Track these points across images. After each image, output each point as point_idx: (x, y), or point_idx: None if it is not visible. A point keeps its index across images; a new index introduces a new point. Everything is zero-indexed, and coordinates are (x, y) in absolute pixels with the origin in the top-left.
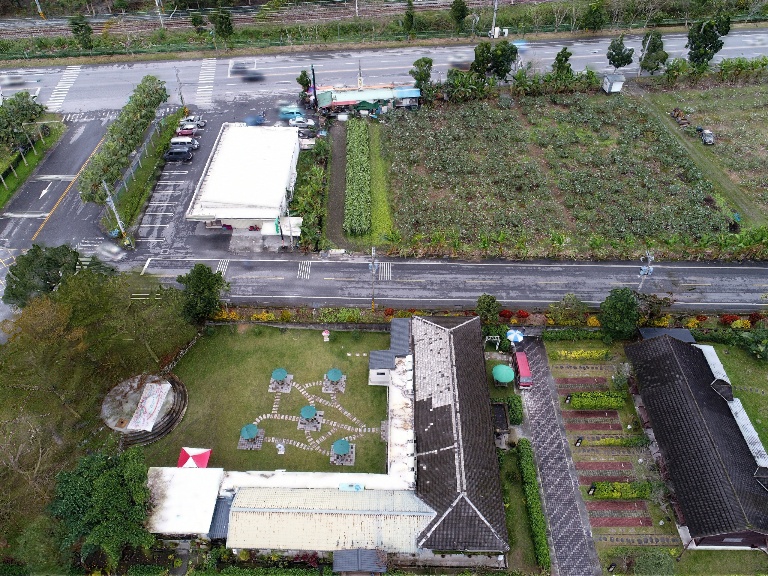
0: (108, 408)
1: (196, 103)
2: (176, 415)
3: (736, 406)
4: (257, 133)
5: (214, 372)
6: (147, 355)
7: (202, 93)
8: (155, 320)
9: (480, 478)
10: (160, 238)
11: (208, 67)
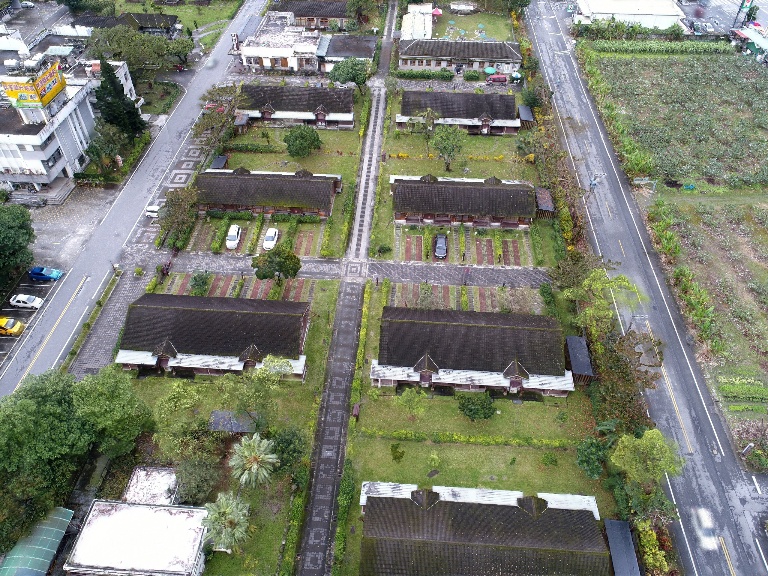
0: (460, 1)
1: (711, 0)
2: (459, 13)
3: (476, 122)
4: (665, 3)
5: (483, 19)
6: (488, 5)
7: (727, 1)
8: (509, 6)
9: (426, 47)
10: (567, 3)
11: (767, 0)
